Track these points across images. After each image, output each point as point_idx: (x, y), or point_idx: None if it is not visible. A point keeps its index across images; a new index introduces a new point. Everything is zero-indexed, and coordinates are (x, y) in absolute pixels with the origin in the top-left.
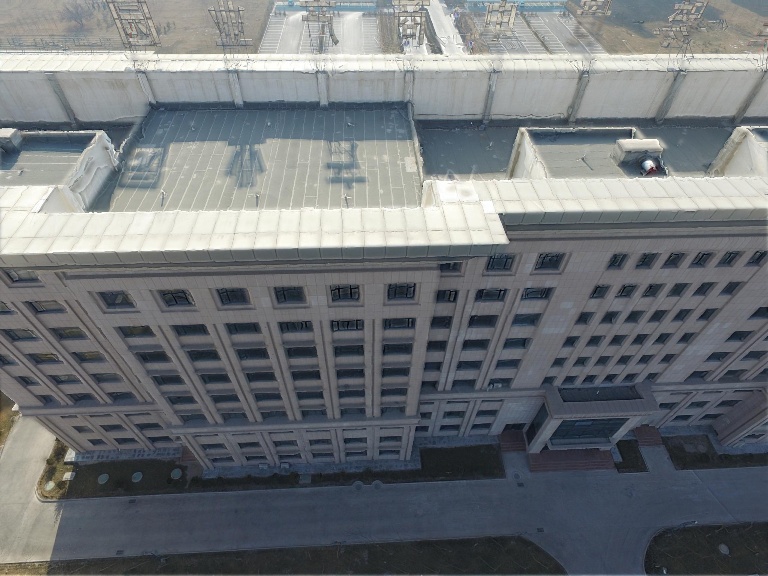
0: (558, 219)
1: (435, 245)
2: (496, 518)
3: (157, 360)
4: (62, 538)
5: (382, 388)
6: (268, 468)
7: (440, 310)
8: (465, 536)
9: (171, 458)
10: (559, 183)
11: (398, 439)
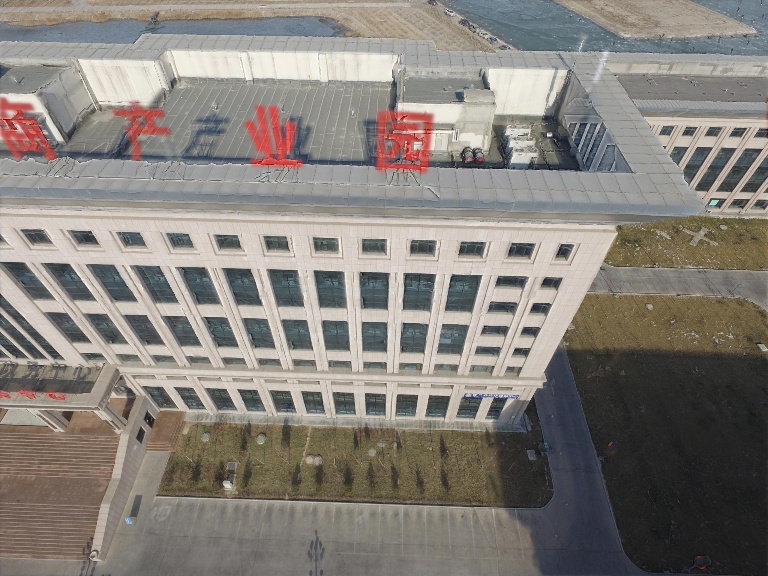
0: None
1: None
2: None
3: None
4: None
5: None
6: None
7: None
8: None
9: None
10: None
11: None
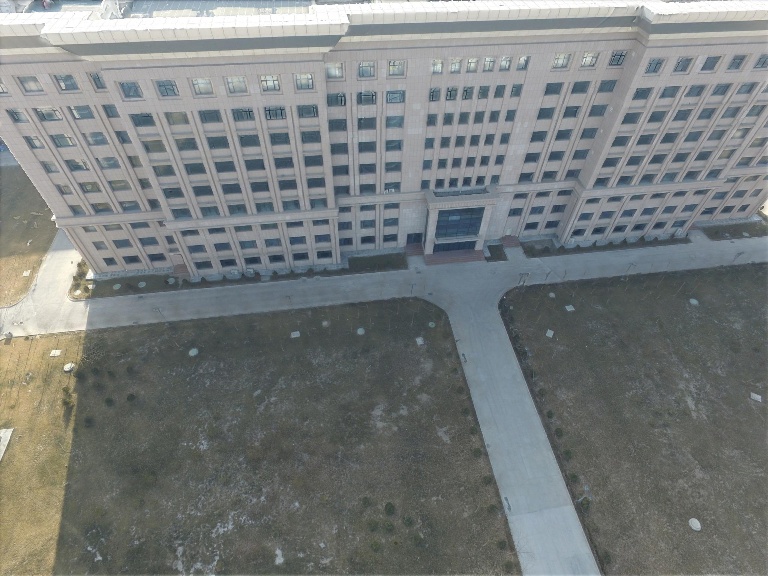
0: (382, 19)
1: (309, 24)
2: (400, 290)
3: (156, 151)
4: (92, 318)
5: (307, 177)
6: (238, 273)
7: (337, 113)
8: (378, 299)
9: (166, 273)
10: (385, 4)
11: (328, 240)
